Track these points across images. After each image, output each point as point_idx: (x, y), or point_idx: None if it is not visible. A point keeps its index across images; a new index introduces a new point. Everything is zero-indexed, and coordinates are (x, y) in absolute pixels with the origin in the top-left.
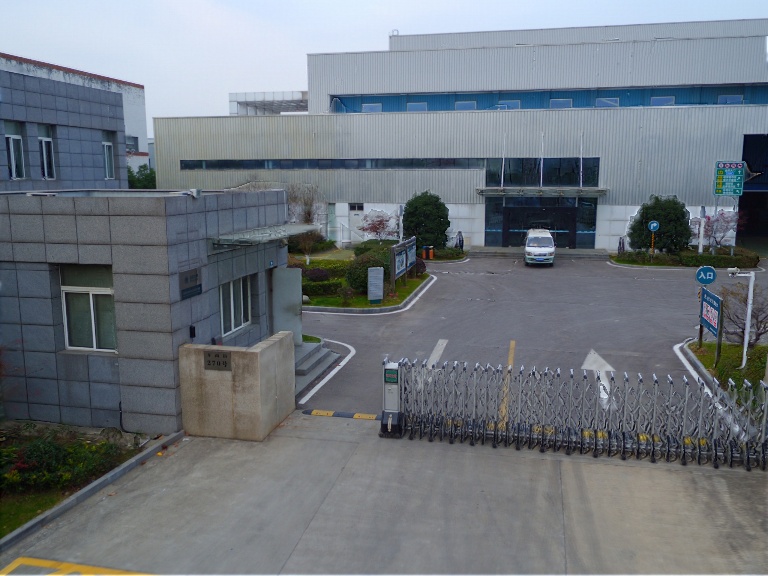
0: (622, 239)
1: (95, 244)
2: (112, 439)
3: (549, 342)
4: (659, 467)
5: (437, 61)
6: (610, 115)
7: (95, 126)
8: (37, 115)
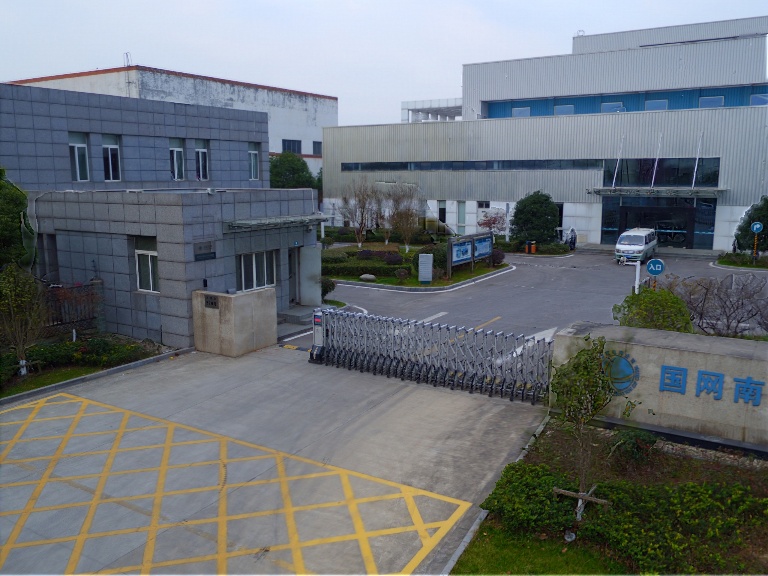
0: (734, 240)
1: (148, 223)
2: (149, 346)
3: (528, 320)
4: (471, 396)
5: (582, 65)
6: (732, 114)
7: (242, 139)
8: (195, 133)
